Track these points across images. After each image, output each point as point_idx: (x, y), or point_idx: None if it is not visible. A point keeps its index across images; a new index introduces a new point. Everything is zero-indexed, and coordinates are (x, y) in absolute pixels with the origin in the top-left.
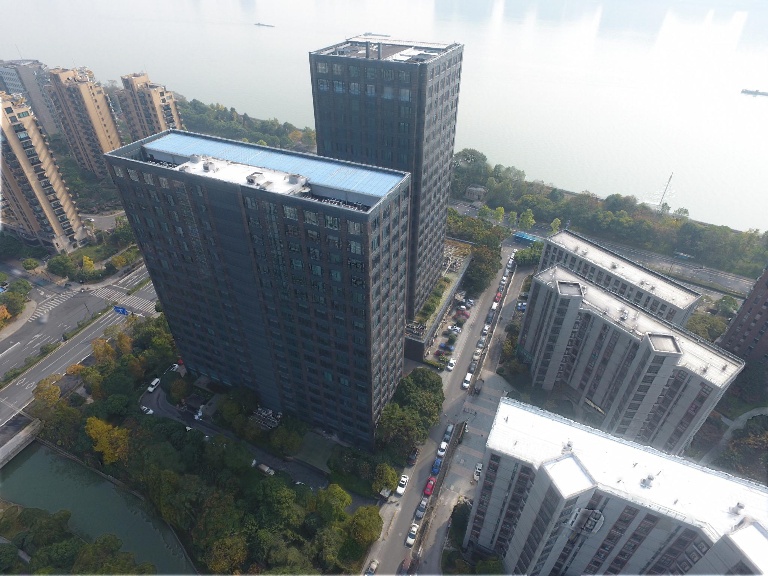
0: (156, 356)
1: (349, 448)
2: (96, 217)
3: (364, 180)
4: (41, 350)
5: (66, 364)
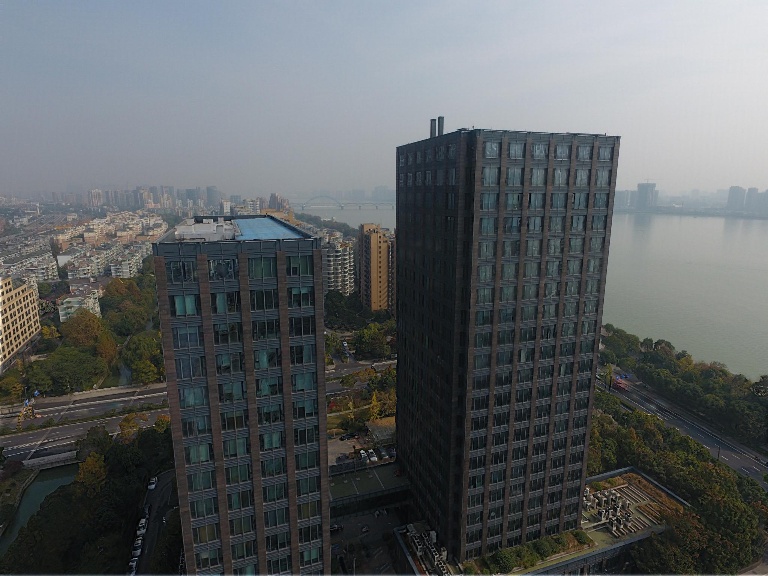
0: None
1: None
2: (330, 332)
3: None
4: None
5: None
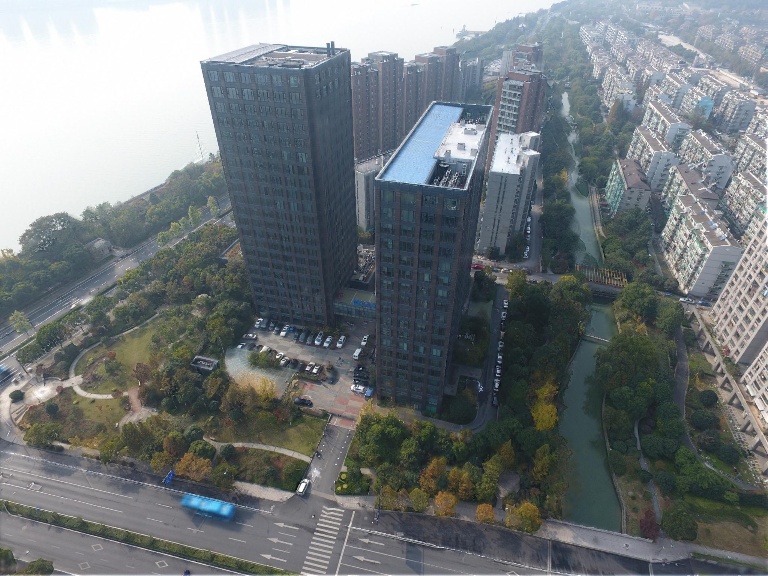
0: None
1: (475, 291)
2: None
3: (445, 112)
4: None
5: (465, 570)
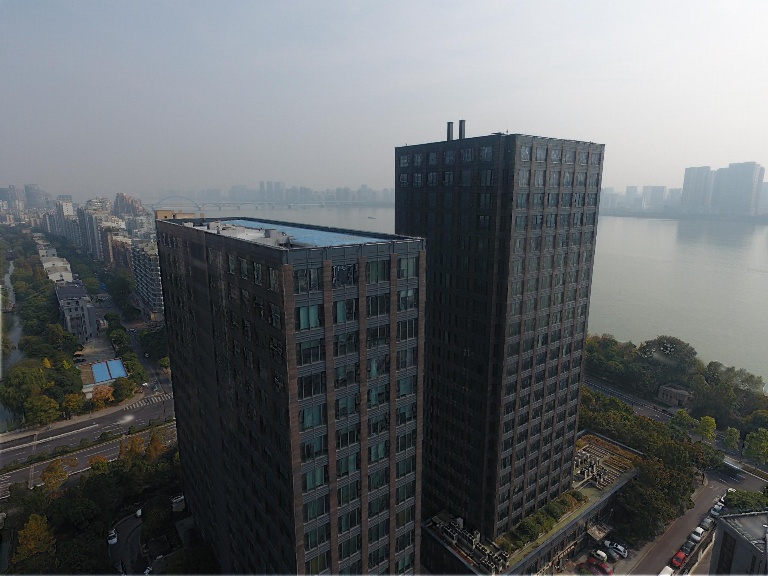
0: (167, 473)
1: None
2: None
3: (355, 242)
4: (101, 436)
5: (107, 457)
